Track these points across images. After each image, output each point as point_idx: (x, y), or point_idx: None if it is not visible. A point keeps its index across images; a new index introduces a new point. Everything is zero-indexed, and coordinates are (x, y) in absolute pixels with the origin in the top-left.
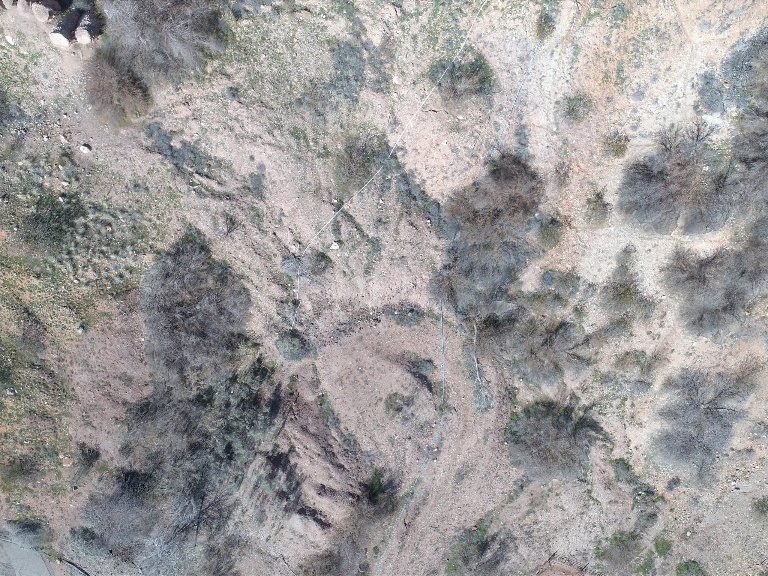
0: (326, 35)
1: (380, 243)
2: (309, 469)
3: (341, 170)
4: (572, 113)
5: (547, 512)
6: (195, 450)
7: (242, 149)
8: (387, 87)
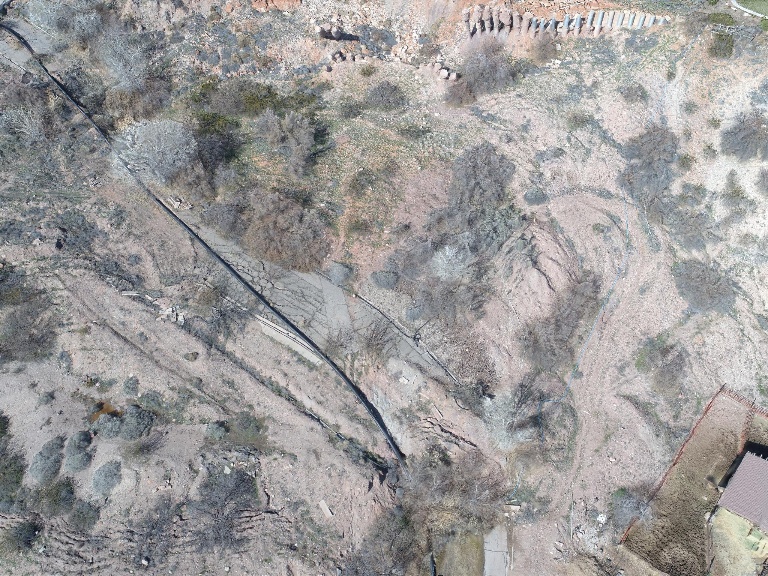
0: (565, 82)
1: (591, 151)
2: (544, 247)
3: (571, 121)
4: (689, 110)
5: (711, 335)
6: (472, 228)
7: (520, 113)
8: (595, 97)
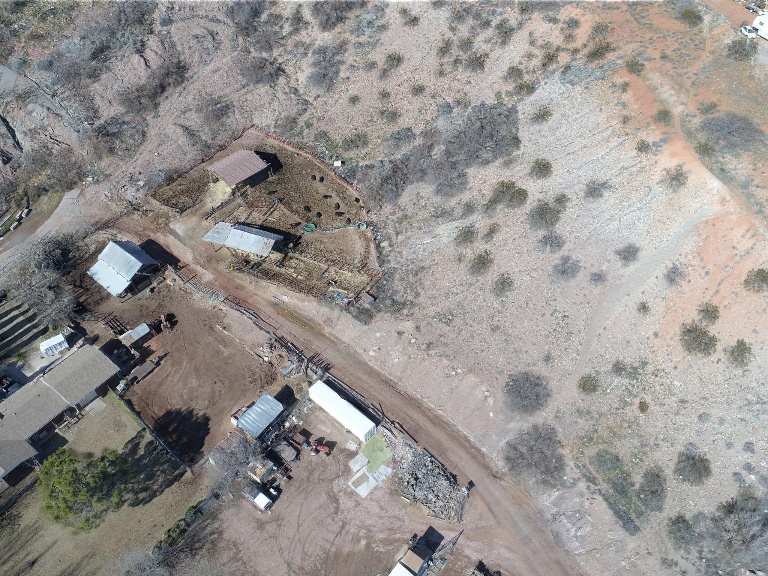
0: None
1: None
2: (151, 44)
3: None
4: None
5: (252, 95)
6: None
7: None
8: None
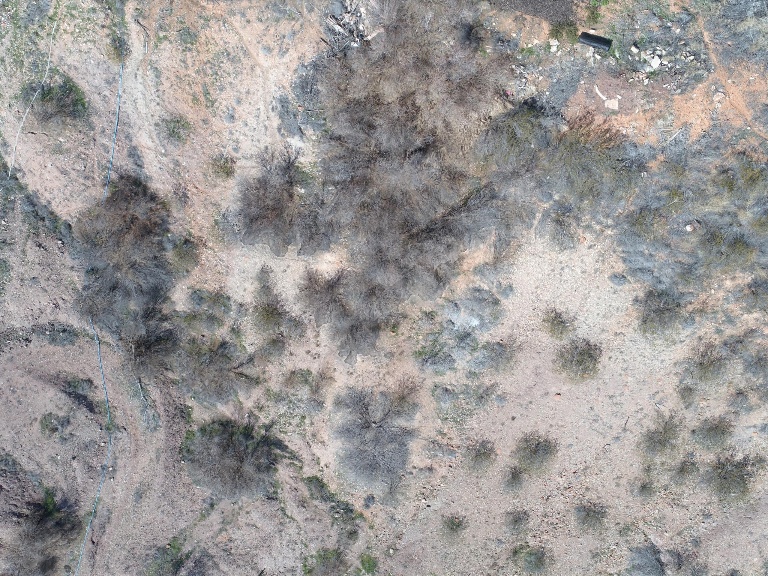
0: None
1: (8, 264)
2: None
3: None
4: (174, 135)
5: (239, 530)
6: None
7: None
8: None
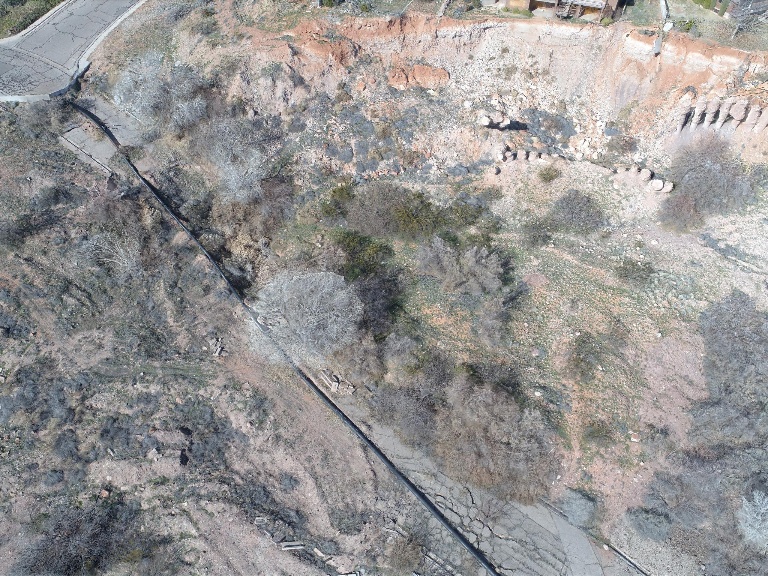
0: None
1: None
2: None
3: None
4: None
5: None
6: (762, 442)
7: None
8: None
